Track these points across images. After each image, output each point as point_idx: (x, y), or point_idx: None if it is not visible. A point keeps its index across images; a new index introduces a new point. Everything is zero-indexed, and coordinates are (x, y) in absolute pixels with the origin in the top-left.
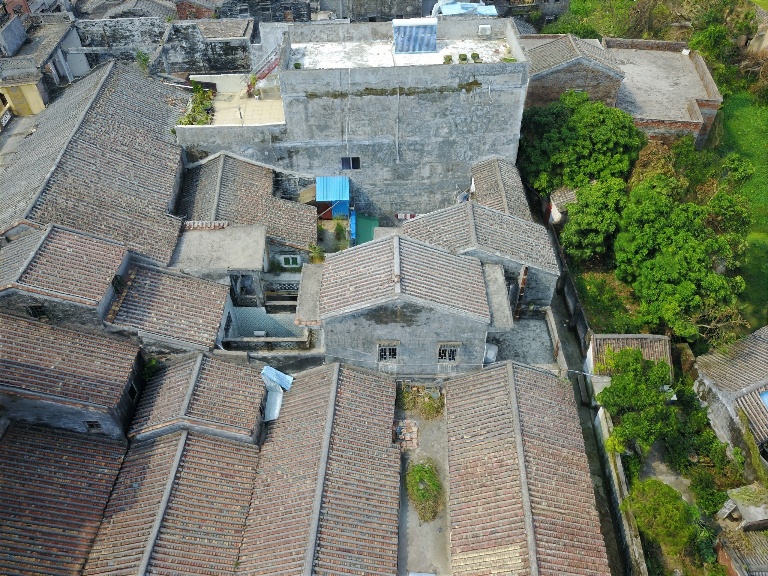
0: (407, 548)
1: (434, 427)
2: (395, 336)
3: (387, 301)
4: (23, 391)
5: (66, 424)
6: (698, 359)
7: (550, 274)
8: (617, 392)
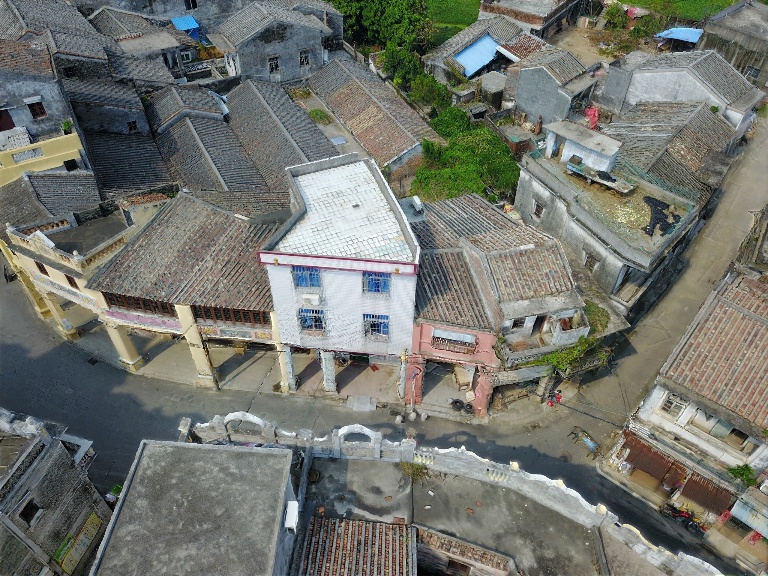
0: (324, 134)
1: (311, 100)
2: (276, 51)
3: (269, 24)
4: (94, 101)
5: (117, 128)
6: (422, 57)
7: (338, 16)
8: (390, 59)
